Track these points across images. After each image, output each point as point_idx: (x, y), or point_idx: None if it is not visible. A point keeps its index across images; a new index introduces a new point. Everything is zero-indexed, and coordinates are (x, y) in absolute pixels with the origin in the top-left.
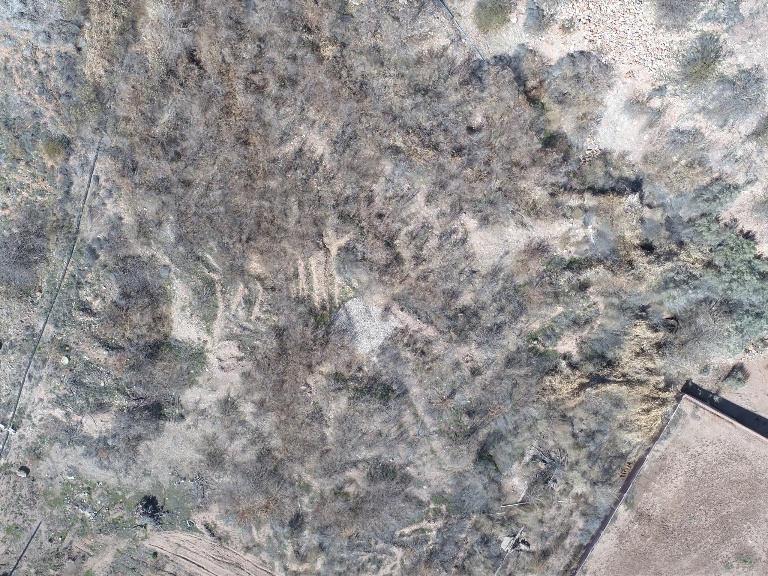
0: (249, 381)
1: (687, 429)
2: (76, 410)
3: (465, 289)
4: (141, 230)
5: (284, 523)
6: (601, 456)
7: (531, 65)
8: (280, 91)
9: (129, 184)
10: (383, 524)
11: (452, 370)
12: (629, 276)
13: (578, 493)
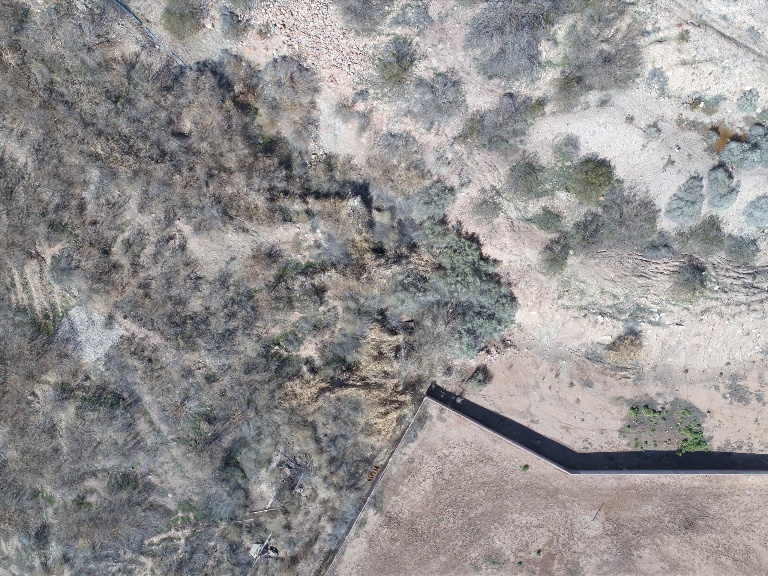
0: None
1: (434, 431)
2: None
3: (193, 295)
4: None
5: (31, 535)
6: (347, 460)
7: (236, 70)
8: None
9: None
10: (125, 534)
11: (183, 377)
12: (363, 280)
13: (325, 498)
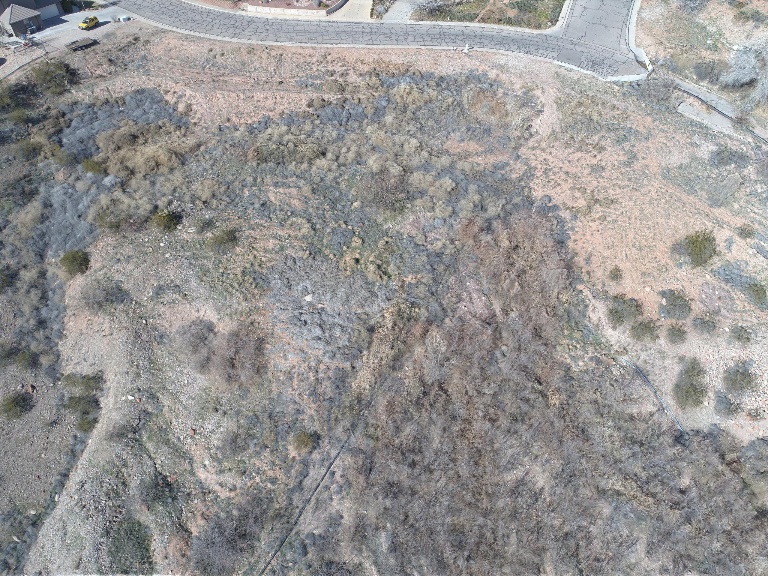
0: None
1: None
2: None
3: None
4: (357, 533)
5: None
6: None
7: (726, 442)
8: (511, 424)
9: (360, 484)
10: None
11: None
12: None
13: None
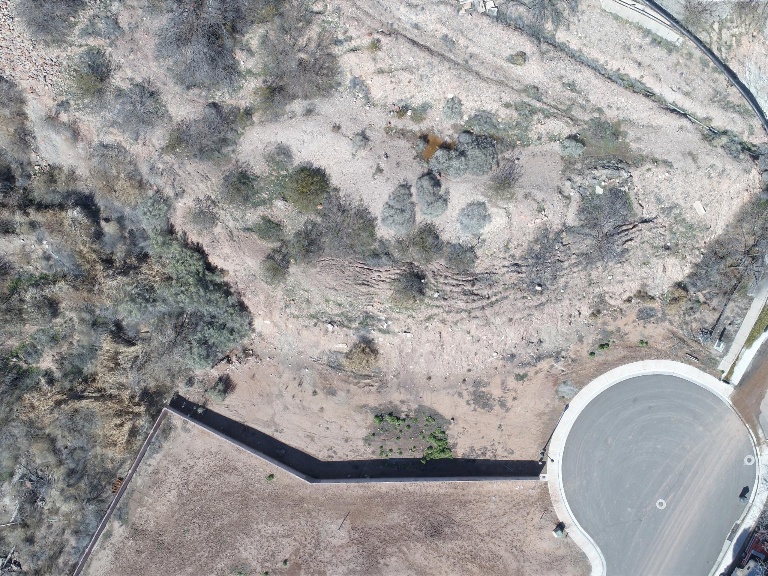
0: None
1: (178, 442)
2: None
3: None
4: None
5: None
6: (89, 472)
7: None
8: None
9: None
10: None
11: None
12: (96, 291)
13: (67, 511)
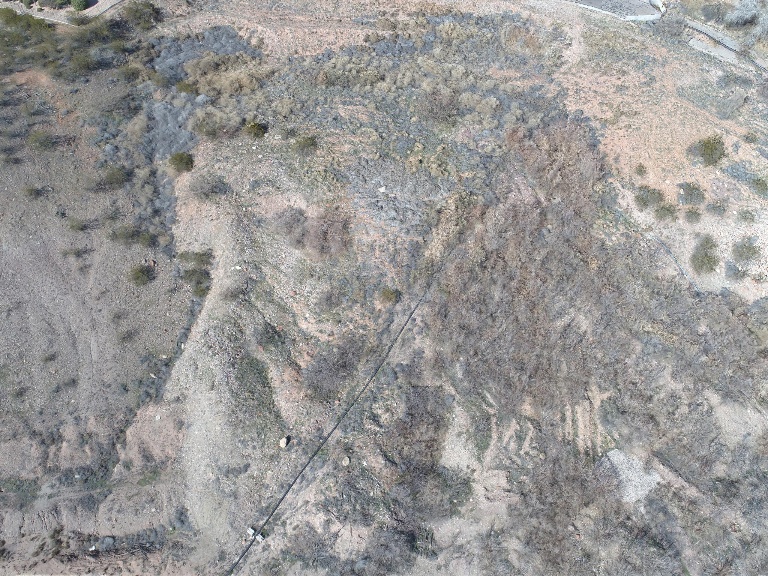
0: (515, 514)
1: None
2: (339, 517)
3: (717, 460)
4: (436, 364)
5: None
6: None
7: (735, 300)
8: (559, 283)
9: (437, 327)
10: None
11: (722, 536)
12: None
13: None
